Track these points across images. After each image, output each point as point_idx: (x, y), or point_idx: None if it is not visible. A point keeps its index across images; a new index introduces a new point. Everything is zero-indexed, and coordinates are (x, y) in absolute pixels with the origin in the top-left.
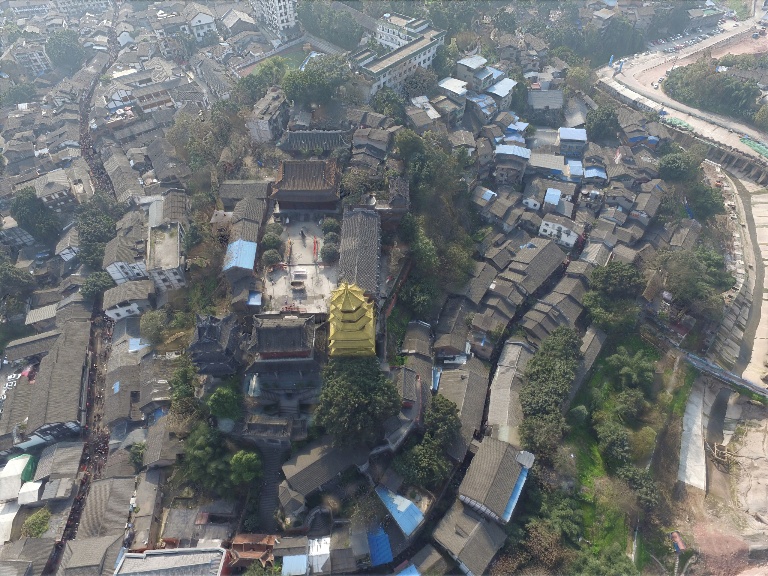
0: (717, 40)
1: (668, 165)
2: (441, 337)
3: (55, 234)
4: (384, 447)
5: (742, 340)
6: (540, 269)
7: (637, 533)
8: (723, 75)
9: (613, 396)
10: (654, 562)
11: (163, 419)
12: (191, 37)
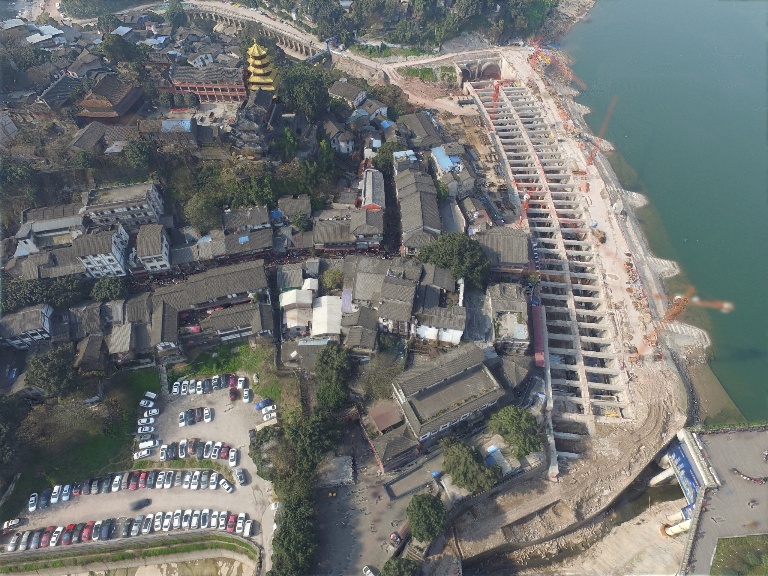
0: None
1: (174, 16)
2: None
3: None
4: None
5: (290, 59)
6: None
7: None
8: None
9: None
10: None
11: (281, 203)
12: None
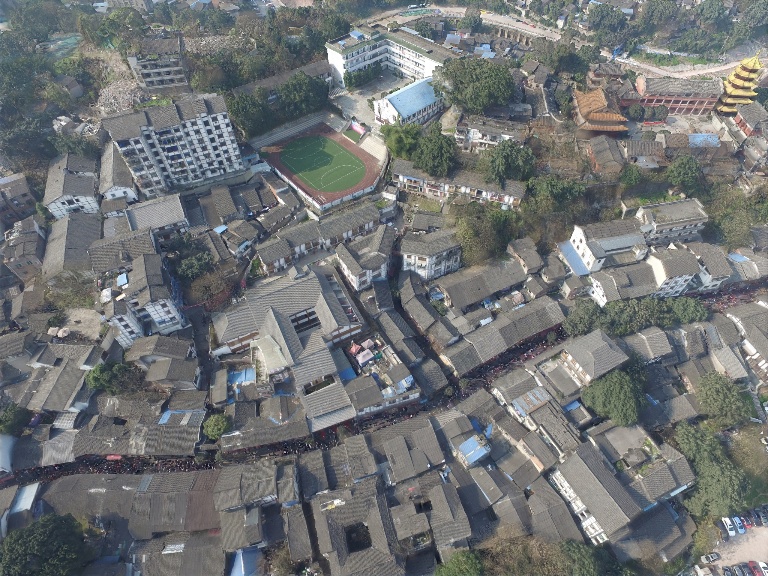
0: None
1: (476, 24)
2: None
3: None
4: None
5: None
6: None
7: None
8: None
9: None
10: None
11: None
12: (207, 254)
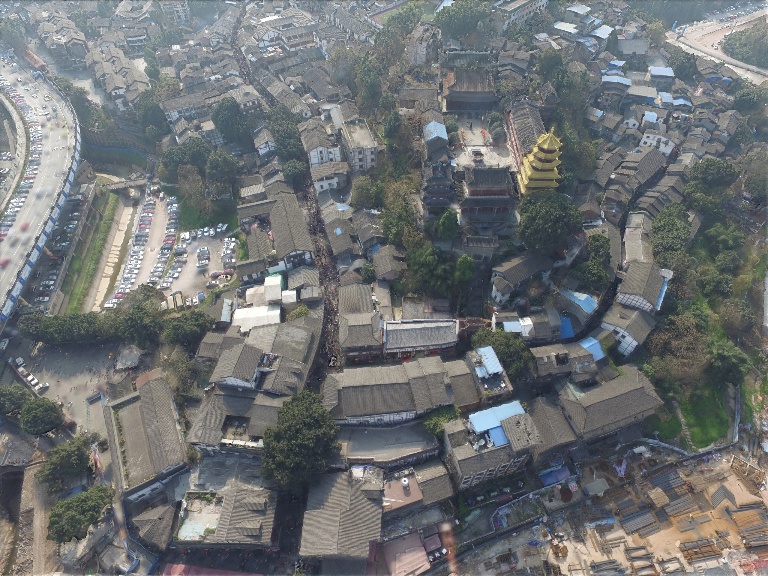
0: (767, 12)
1: (743, 97)
2: (581, 206)
3: (247, 135)
4: (562, 262)
5: None
6: (648, 167)
7: None
8: None
9: (709, 262)
10: (752, 368)
11: (385, 247)
12: None
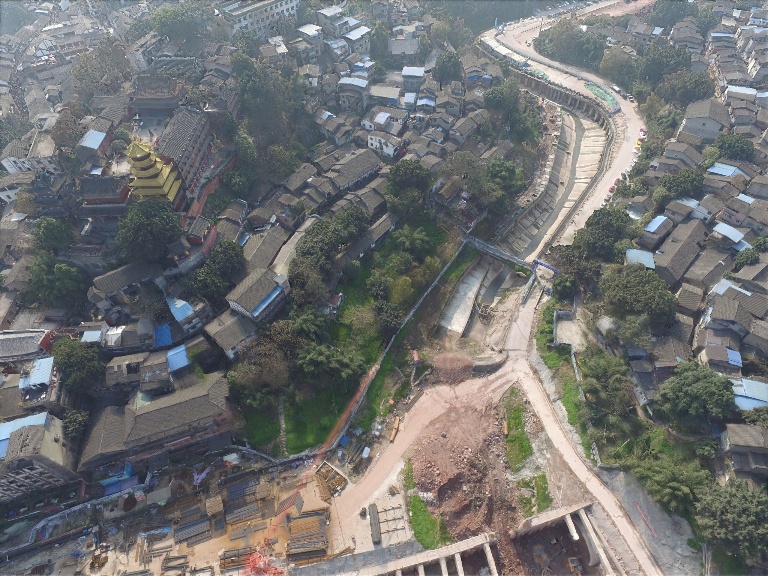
0: (599, 7)
1: (488, 96)
2: (253, 210)
3: None
4: (176, 269)
5: (535, 235)
6: (354, 169)
7: (388, 353)
8: (577, 31)
9: None
10: (396, 372)
11: None
12: None
